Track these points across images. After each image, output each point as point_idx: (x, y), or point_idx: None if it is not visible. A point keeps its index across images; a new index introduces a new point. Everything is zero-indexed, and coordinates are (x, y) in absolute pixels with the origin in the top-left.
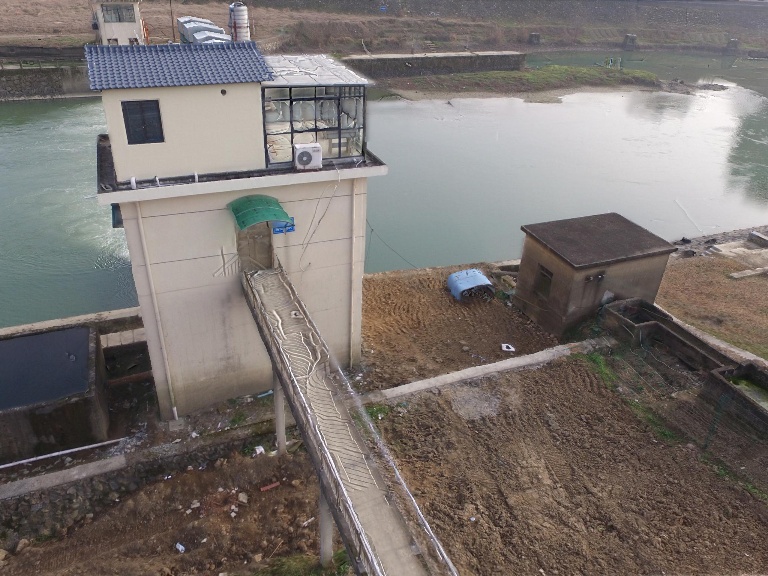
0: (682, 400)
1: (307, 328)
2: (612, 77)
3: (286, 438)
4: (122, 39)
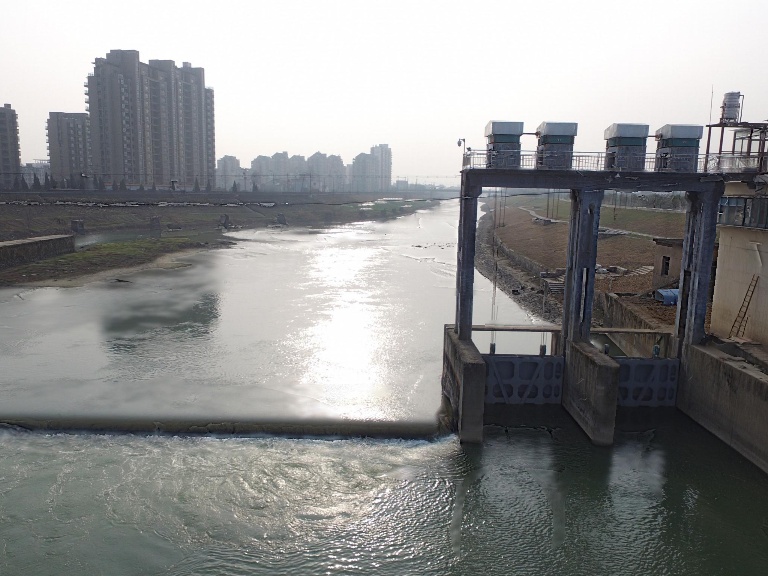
0: None
1: None
2: (168, 245)
3: None
4: None
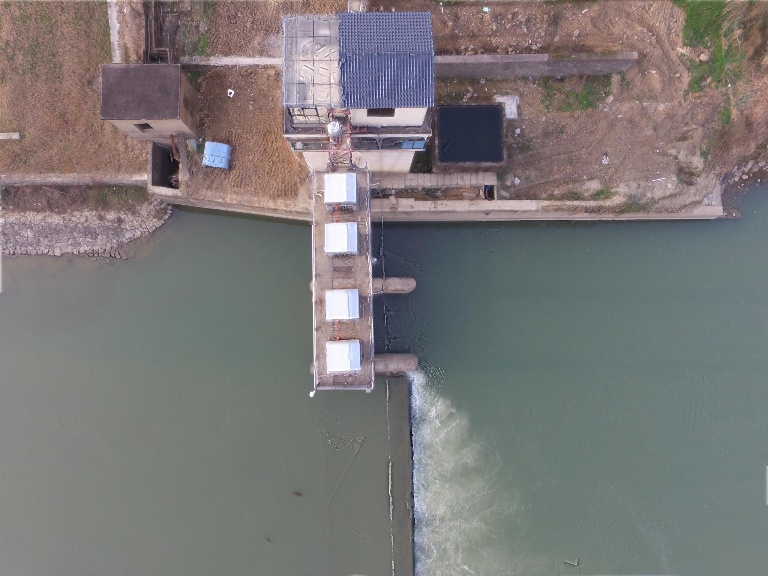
0: (190, 2)
1: (351, 2)
2: None
3: None
4: None
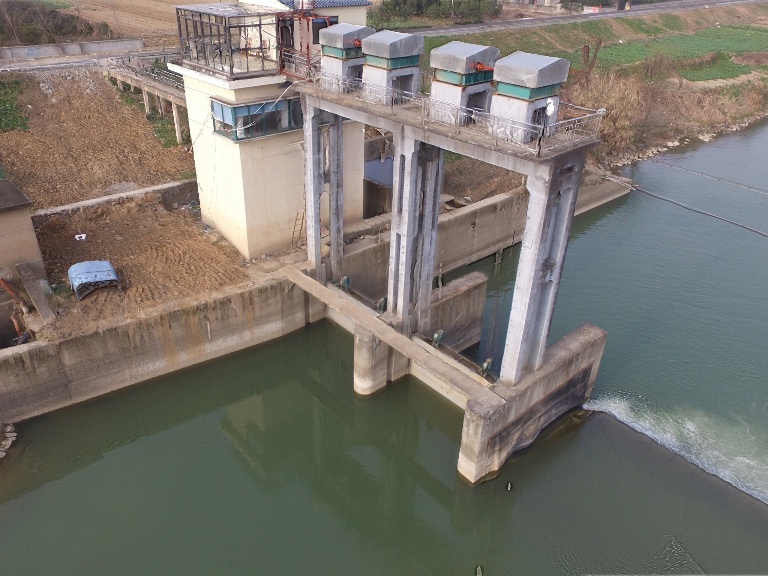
0: None
1: None
2: None
3: None
4: None
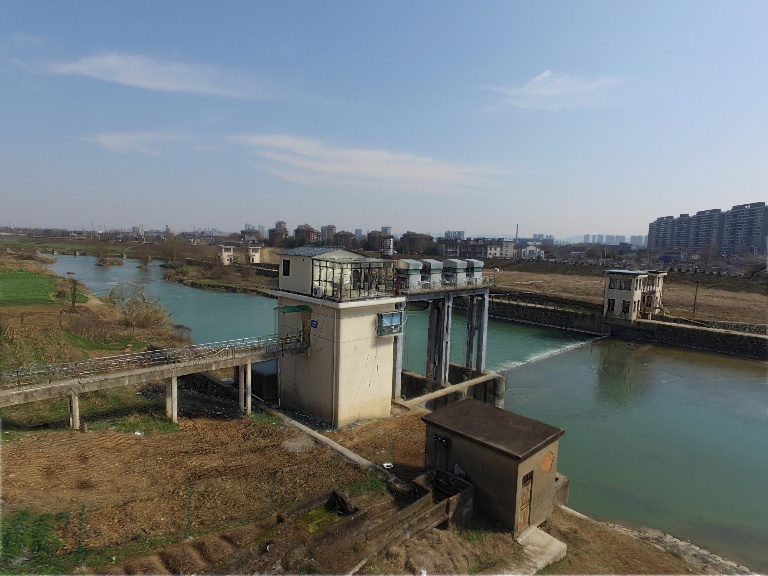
0: None
1: None
2: None
3: (254, 410)
4: (618, 300)
